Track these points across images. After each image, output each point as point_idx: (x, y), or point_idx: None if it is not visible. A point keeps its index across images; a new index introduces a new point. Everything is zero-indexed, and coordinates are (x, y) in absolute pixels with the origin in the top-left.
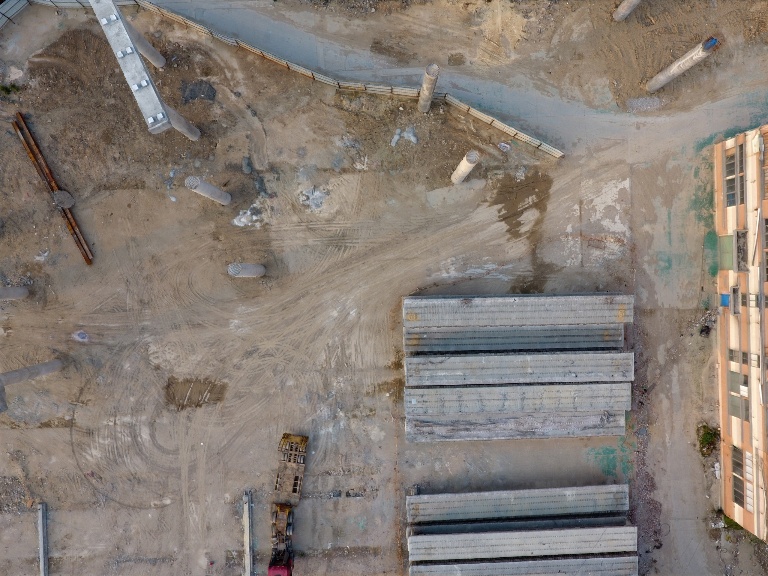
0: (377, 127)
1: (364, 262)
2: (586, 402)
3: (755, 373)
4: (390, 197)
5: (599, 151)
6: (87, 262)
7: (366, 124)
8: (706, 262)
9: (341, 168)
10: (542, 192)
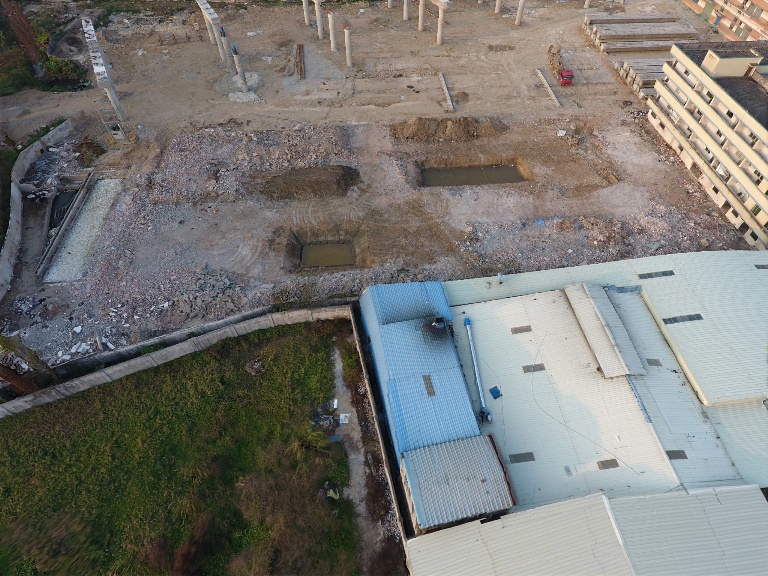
0: (549, 0)
1: (559, 22)
2: (678, 31)
3: (741, 17)
4: (562, 11)
5: (638, 2)
6: (447, 23)
7: (545, 0)
8: (701, 19)
9: (540, 7)
10: (622, 9)
